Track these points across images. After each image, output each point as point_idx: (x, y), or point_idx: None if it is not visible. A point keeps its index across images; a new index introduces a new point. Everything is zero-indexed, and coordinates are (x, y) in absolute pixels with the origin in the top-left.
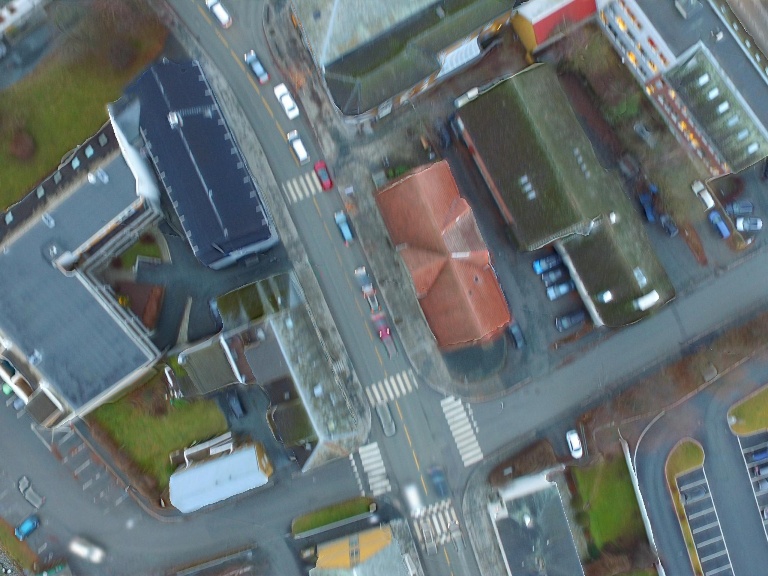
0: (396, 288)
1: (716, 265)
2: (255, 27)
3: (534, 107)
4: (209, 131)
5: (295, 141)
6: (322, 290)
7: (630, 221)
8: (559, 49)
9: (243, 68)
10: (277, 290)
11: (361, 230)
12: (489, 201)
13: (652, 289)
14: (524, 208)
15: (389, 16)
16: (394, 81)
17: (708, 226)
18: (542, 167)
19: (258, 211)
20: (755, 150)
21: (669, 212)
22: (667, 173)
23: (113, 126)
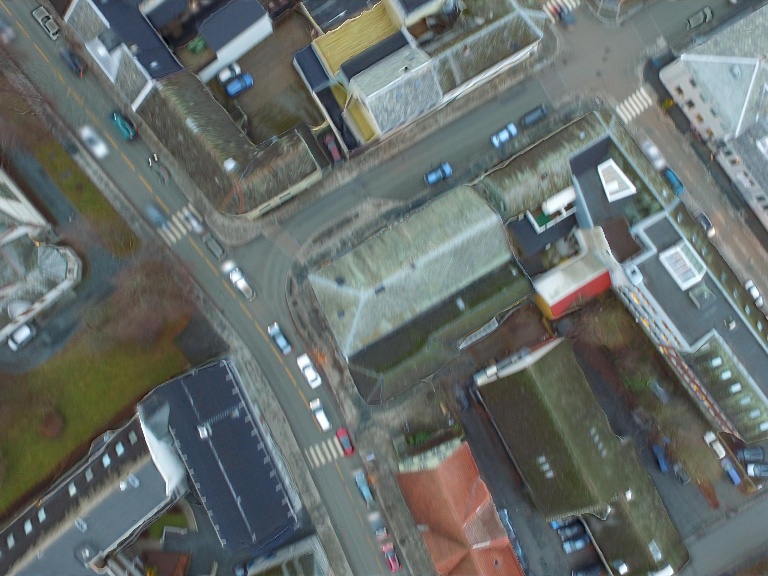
0: (416, 547)
1: (727, 508)
2: (278, 298)
3: (552, 394)
4: (237, 432)
5: (318, 412)
6: (344, 551)
7: (645, 491)
8: (575, 316)
9: (267, 339)
10: (302, 574)
11: (382, 493)
12: (507, 461)
13: (667, 564)
14: (542, 485)
15: (411, 309)
16: (416, 373)
17: (720, 471)
18: (560, 451)
19: (284, 503)
20: (767, 429)
21: (682, 461)
22: (680, 425)
23: (144, 432)
